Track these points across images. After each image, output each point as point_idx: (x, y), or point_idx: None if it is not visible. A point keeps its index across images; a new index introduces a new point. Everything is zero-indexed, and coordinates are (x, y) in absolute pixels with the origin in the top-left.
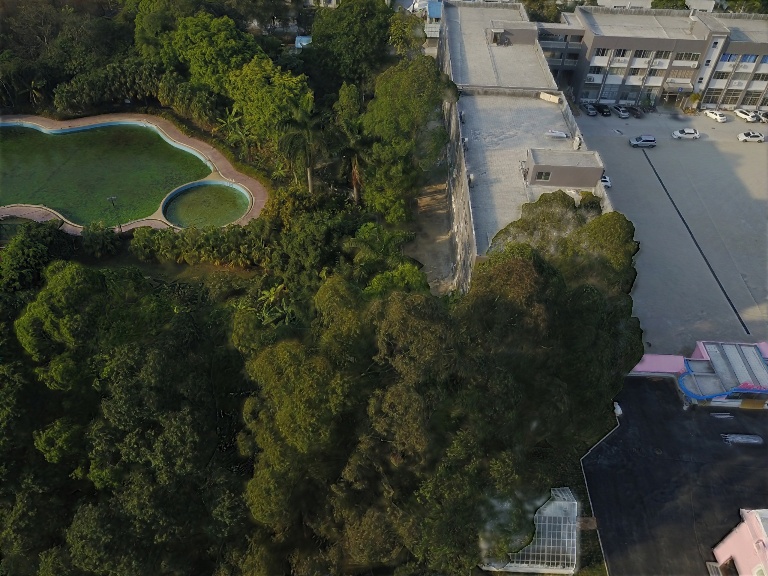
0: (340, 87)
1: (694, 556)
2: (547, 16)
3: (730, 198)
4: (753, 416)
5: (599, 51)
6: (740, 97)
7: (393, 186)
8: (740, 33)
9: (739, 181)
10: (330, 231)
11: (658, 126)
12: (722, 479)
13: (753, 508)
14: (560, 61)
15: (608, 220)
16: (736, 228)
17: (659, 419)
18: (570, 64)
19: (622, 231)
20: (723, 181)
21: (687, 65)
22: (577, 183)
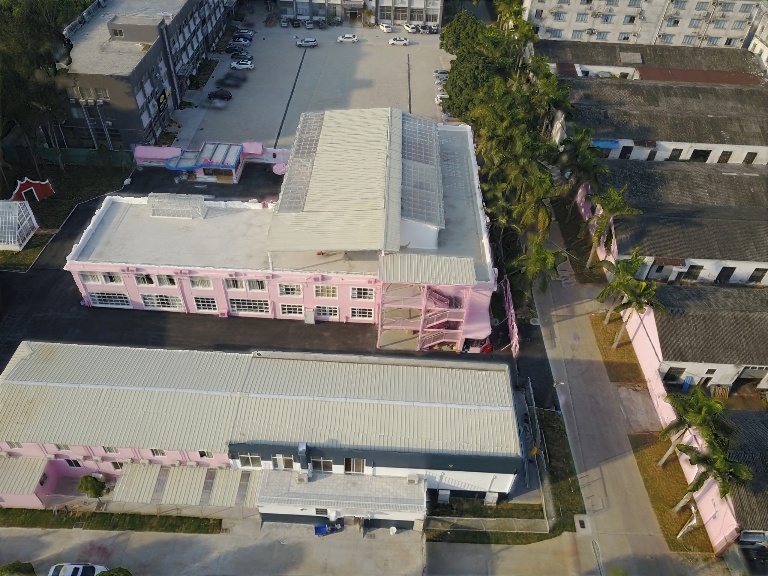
0: None
1: None
2: None
3: (343, 78)
4: (222, 187)
5: None
6: (408, 14)
7: None
8: None
9: (362, 68)
10: None
11: (332, 34)
12: None
13: None
14: None
15: None
16: (329, 95)
17: (153, 187)
18: None
19: None
20: (349, 68)
21: None
22: (146, 39)
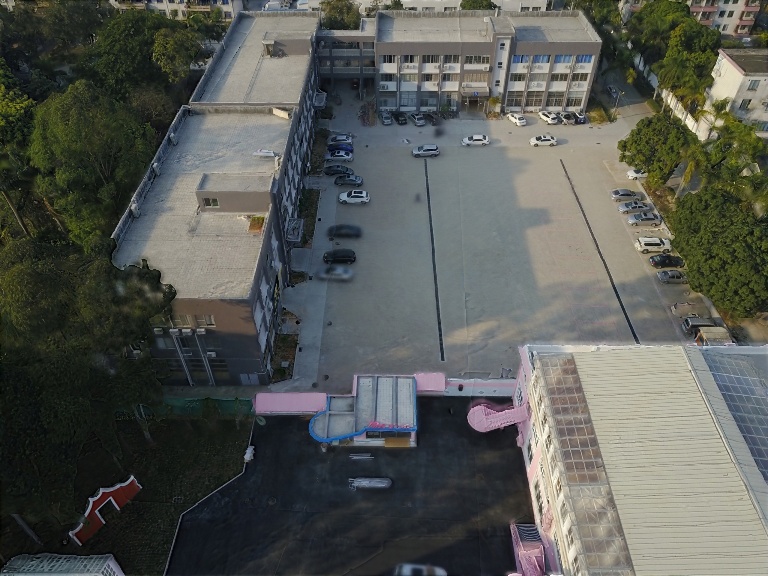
0: None
1: None
2: (347, 23)
3: (492, 209)
4: (395, 456)
5: (386, 58)
6: (543, 99)
7: (85, 217)
8: (539, 32)
9: (511, 189)
10: None
11: (452, 133)
12: (326, 531)
13: (345, 564)
14: (358, 69)
15: (8, 276)
16: (483, 242)
17: (291, 463)
18: (369, 72)
19: (23, 288)
20: (494, 190)
21: (479, 68)
22: (251, 208)
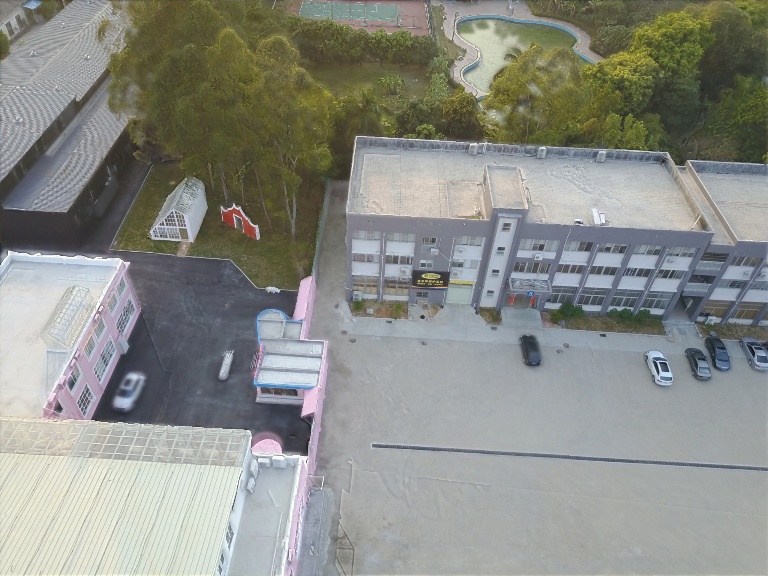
0: (707, 139)
1: (139, 297)
2: None
3: (707, 558)
4: (250, 385)
5: None
6: None
7: None
8: None
9: None
10: (414, 108)
11: None
12: (193, 337)
13: (163, 347)
14: None
15: None
16: (610, 529)
17: None
18: None
19: None
20: None
21: None
22: None
